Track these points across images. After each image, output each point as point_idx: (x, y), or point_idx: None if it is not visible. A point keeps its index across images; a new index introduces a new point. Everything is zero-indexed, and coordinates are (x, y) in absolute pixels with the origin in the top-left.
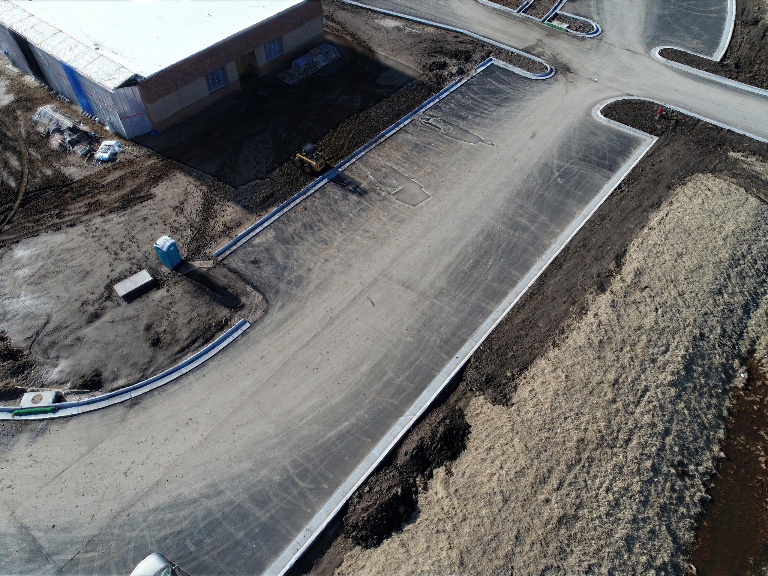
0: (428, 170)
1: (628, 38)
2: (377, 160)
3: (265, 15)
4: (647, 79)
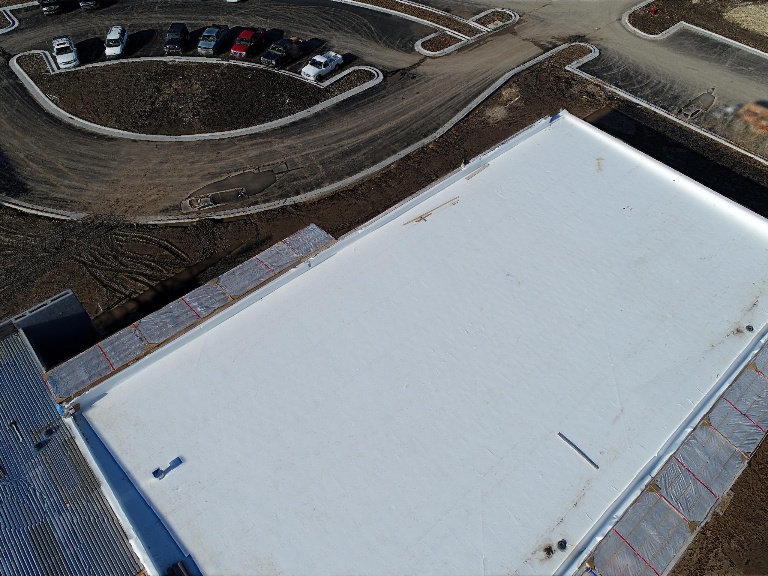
0: (765, 124)
1: (524, 2)
2: (765, 149)
3: (623, 158)
4: (593, 8)
